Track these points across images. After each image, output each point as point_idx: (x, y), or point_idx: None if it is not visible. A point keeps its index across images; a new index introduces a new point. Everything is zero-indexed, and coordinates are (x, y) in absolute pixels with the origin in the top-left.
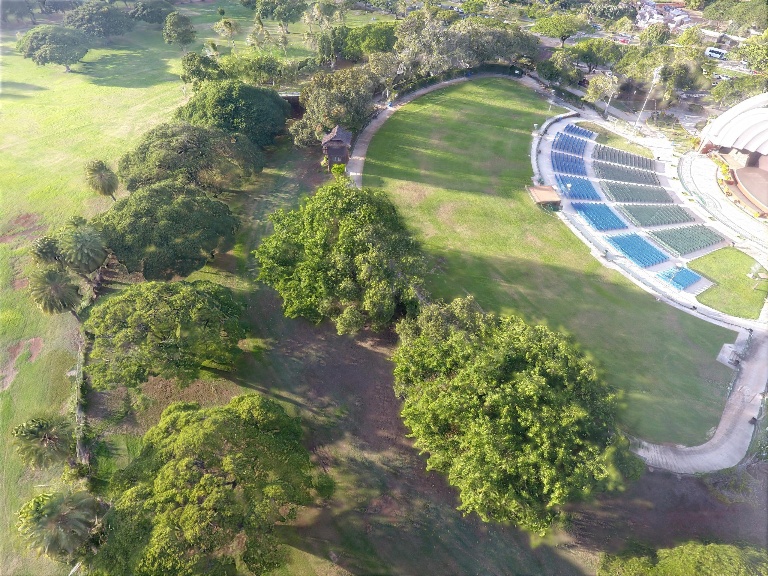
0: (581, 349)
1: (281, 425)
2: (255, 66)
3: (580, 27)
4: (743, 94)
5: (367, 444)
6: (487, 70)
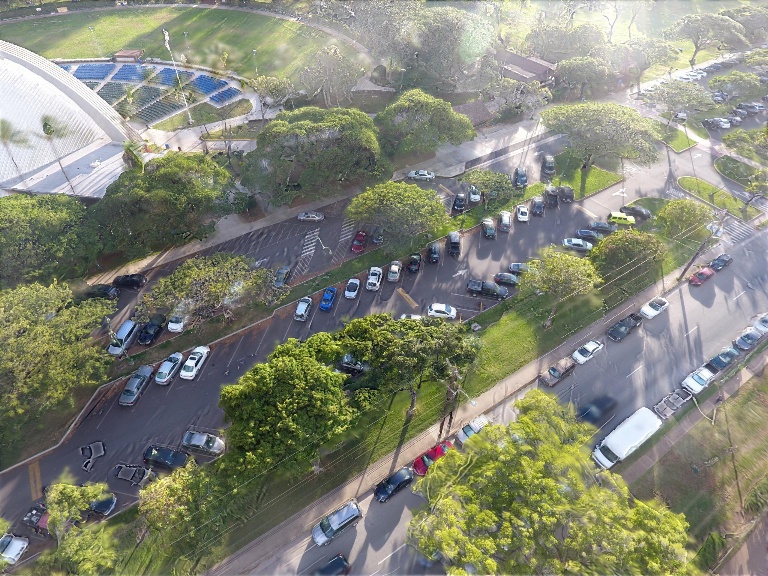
0: (4, 35)
1: None
2: None
3: (574, 131)
4: None
5: None
6: None
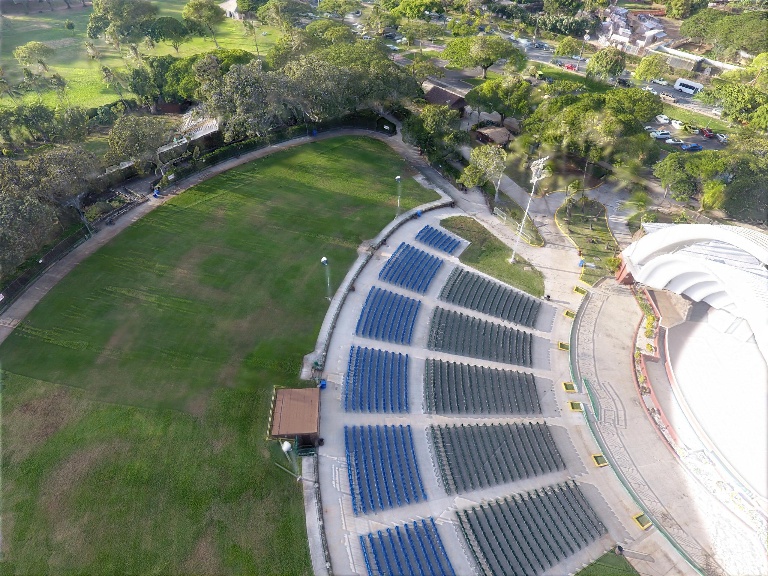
0: None
1: None
2: (1, 122)
3: (502, 53)
4: (698, 181)
5: None
6: (345, 124)
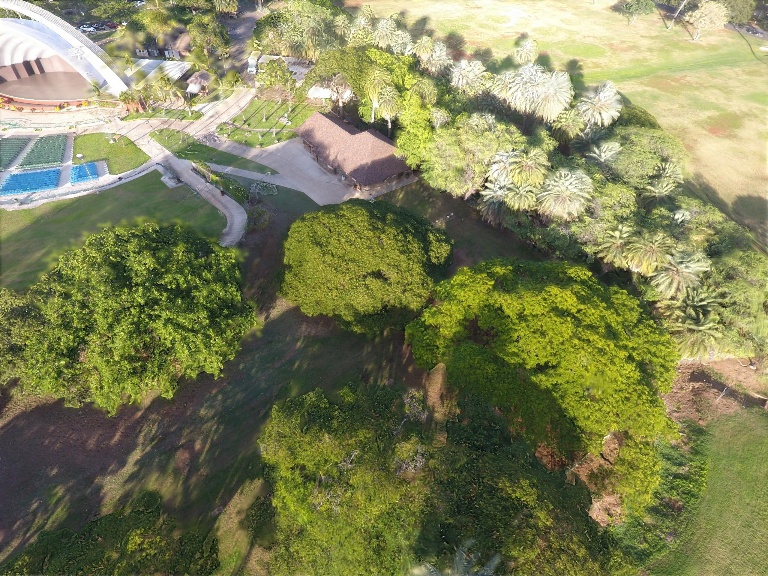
0: None
1: (42, 551)
2: None
3: None
4: None
5: (112, 466)
6: None
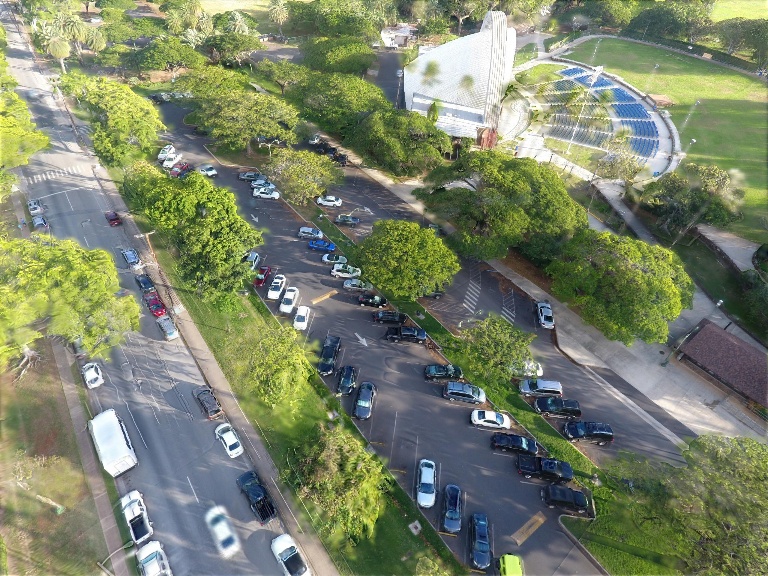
0: None
1: None
2: None
3: None
4: None
5: None
6: None
